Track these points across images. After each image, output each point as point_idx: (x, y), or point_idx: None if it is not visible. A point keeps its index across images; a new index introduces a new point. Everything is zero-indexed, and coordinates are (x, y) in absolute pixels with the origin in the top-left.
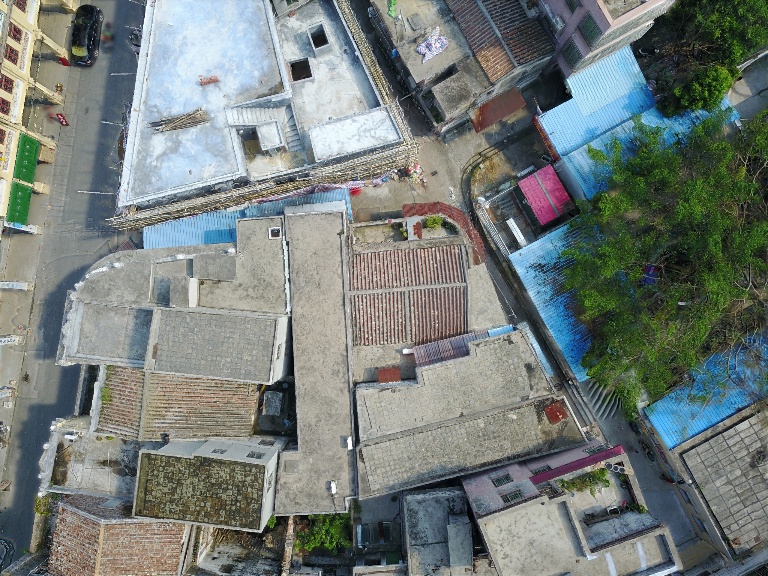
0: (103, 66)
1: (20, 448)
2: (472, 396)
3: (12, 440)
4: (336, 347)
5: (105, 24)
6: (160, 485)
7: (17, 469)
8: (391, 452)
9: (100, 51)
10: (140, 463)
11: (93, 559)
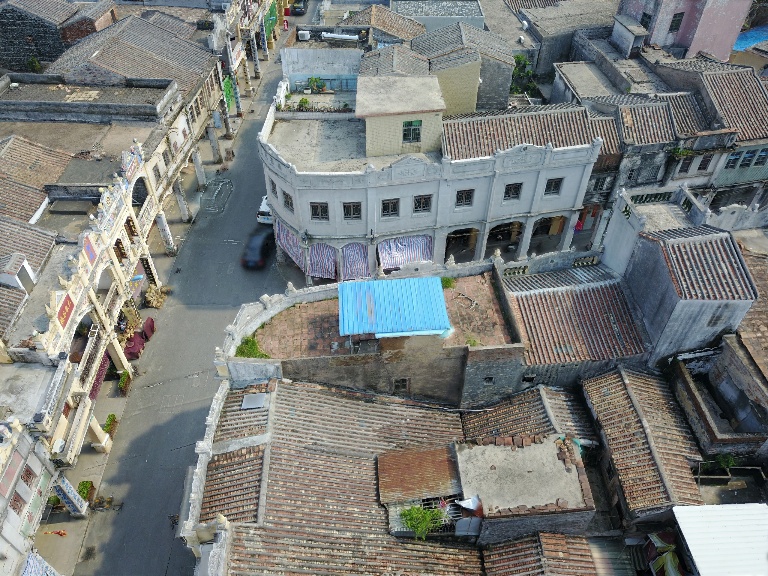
0: (309, 15)
1: (244, 141)
2: (596, 7)
3: (237, 138)
4: (499, 4)
5: (310, 6)
6: (407, 8)
7: (240, 150)
8: (555, 22)
9: (307, 12)
10: (391, 2)
11: (368, 18)
